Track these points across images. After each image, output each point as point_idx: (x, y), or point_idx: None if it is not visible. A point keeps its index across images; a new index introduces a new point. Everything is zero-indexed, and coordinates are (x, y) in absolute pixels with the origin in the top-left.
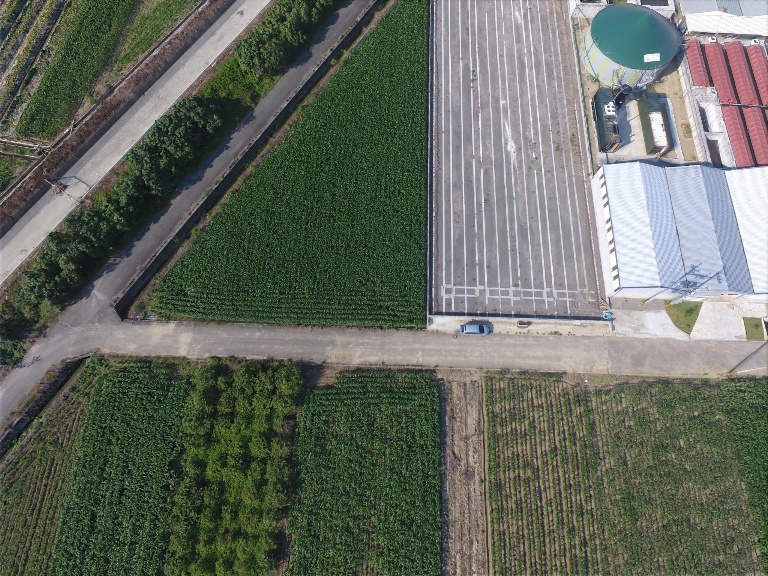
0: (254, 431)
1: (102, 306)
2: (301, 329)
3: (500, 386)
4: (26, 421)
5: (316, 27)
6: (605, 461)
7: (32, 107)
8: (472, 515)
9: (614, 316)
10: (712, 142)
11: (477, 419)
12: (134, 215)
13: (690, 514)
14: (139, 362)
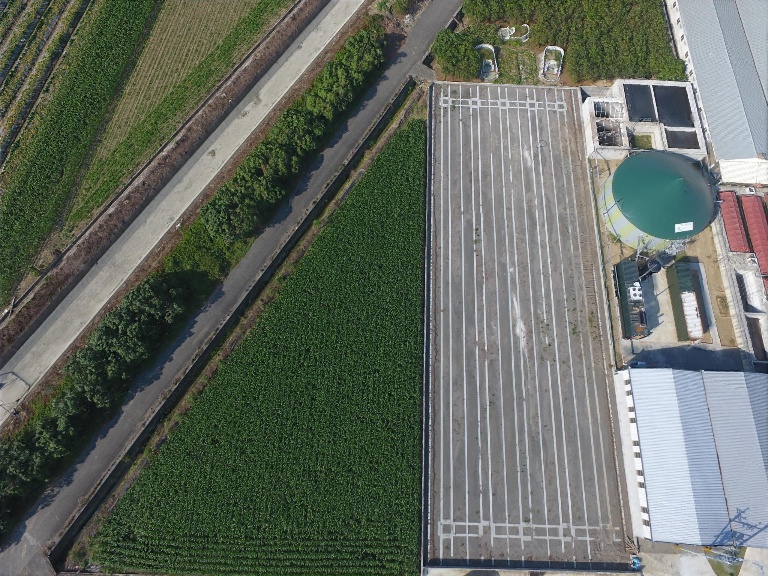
0: None
1: (34, 555)
2: None
3: None
4: None
5: (297, 174)
6: None
7: None
8: None
9: (643, 563)
10: (752, 321)
11: None
12: (76, 434)
13: None
14: None
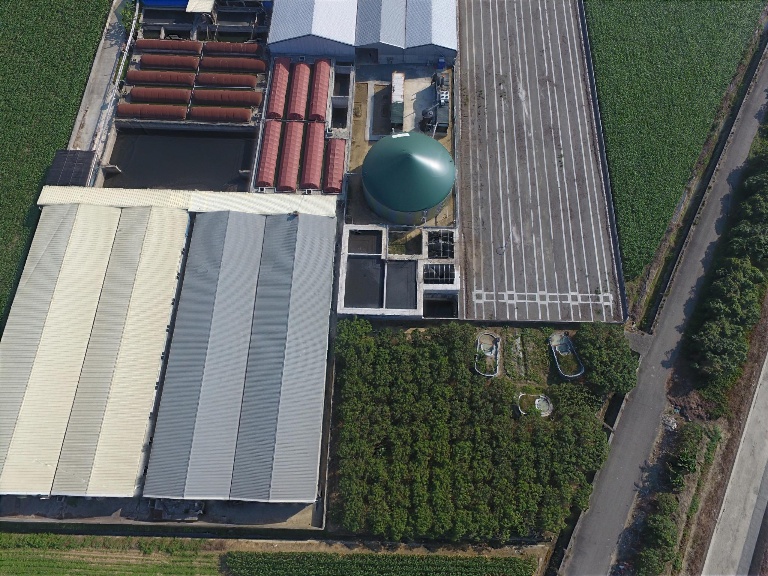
0: None
1: None
2: None
3: None
4: None
5: None
6: None
7: None
8: None
9: None
10: None
11: None
12: None
13: None
14: None
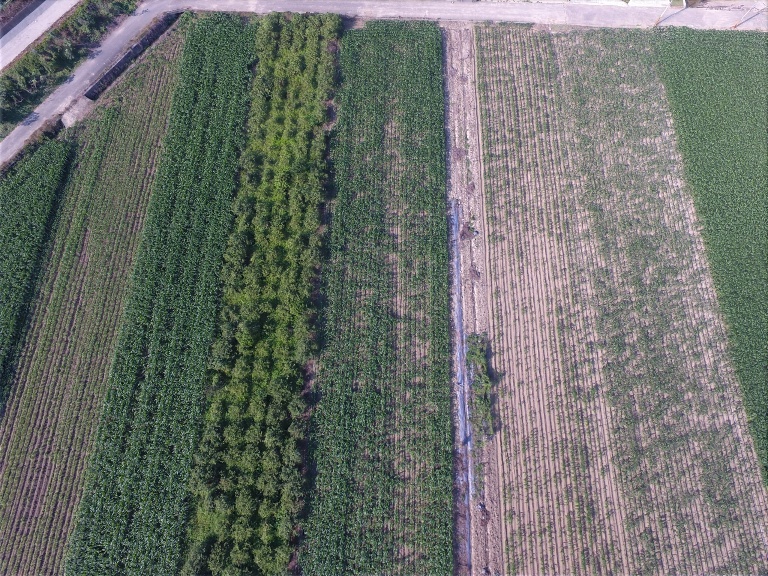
0: None
1: None
2: None
3: (486, 32)
4: (140, 49)
5: None
6: (563, 72)
7: None
8: (466, 100)
9: None
10: None
11: (469, 49)
12: None
13: (623, 99)
14: (221, 12)
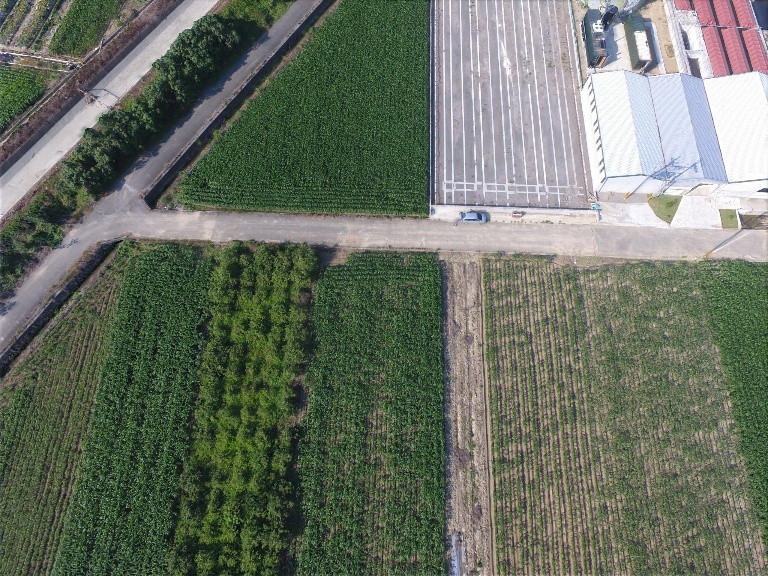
0: (273, 302)
1: (133, 197)
2: (315, 217)
3: (497, 267)
4: (66, 295)
5: None
6: (592, 329)
7: (64, 28)
8: (471, 373)
9: (601, 207)
10: (693, 60)
11: (476, 294)
12: (161, 118)
13: (668, 372)
14: (168, 244)
